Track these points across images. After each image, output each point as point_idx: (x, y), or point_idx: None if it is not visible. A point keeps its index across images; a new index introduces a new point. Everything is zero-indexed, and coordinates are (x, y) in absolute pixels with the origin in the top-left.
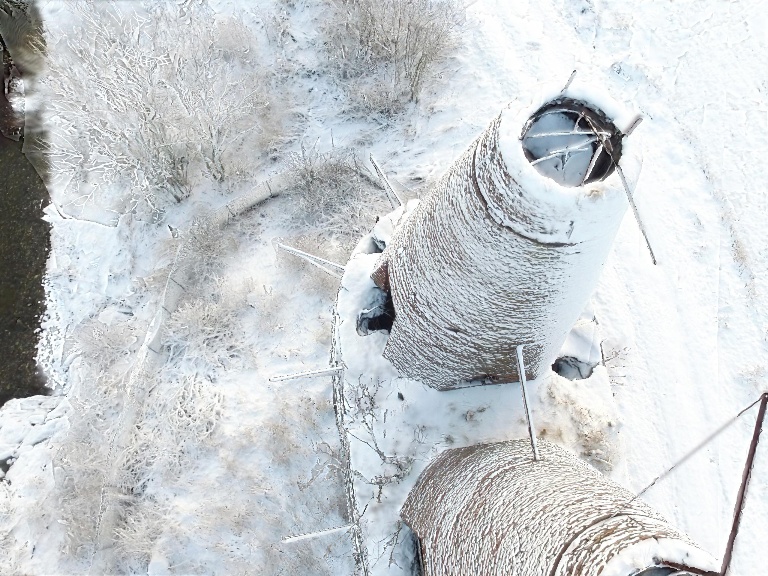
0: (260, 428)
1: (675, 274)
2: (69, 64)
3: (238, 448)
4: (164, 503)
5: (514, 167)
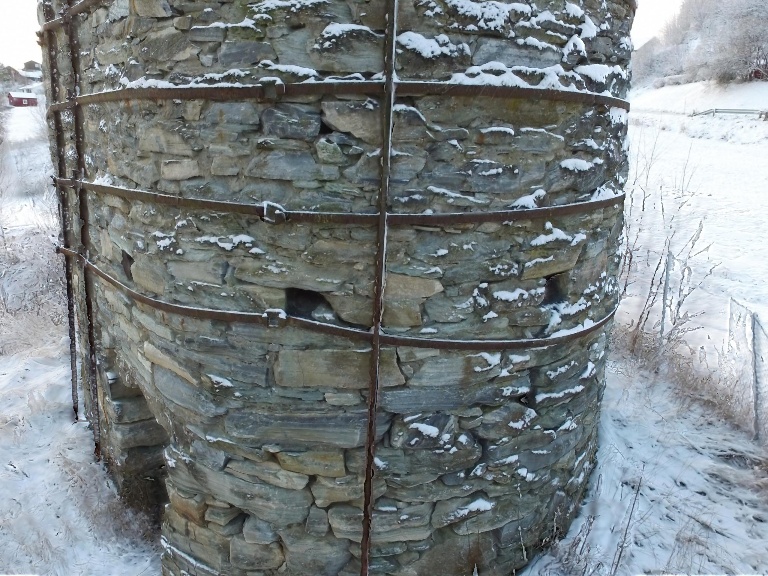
0: None
1: None
2: None
3: None
4: None
5: None
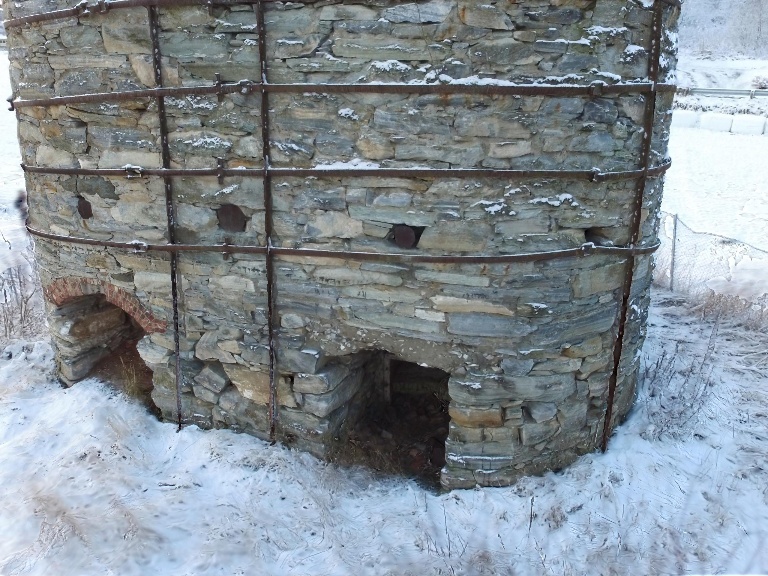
0: (8, 567)
1: None
2: None
3: None
4: None
5: None
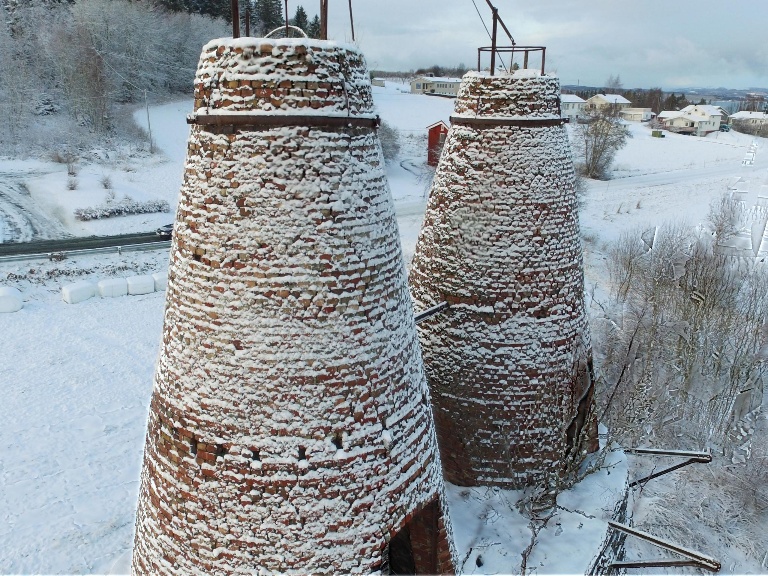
0: None
1: None
2: None
3: None
4: None
5: None
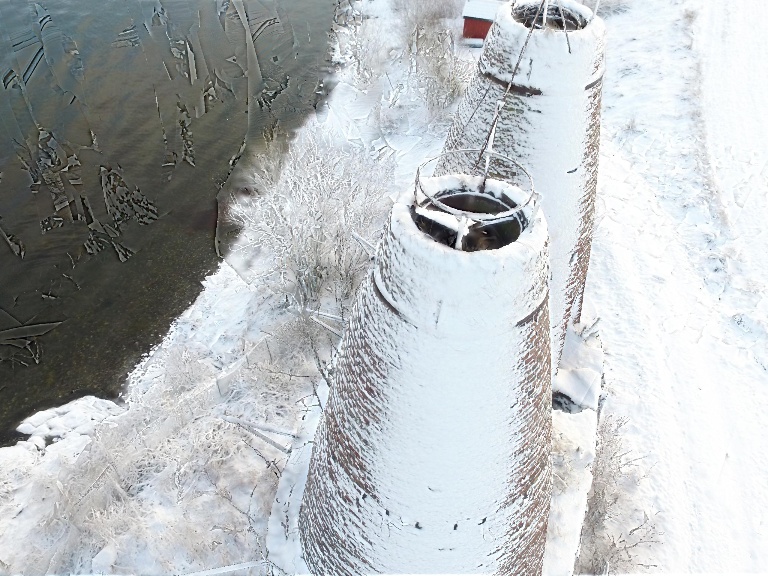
0: (266, 475)
1: (757, 517)
2: (280, 152)
3: (237, 483)
4: (147, 507)
5: (500, 15)
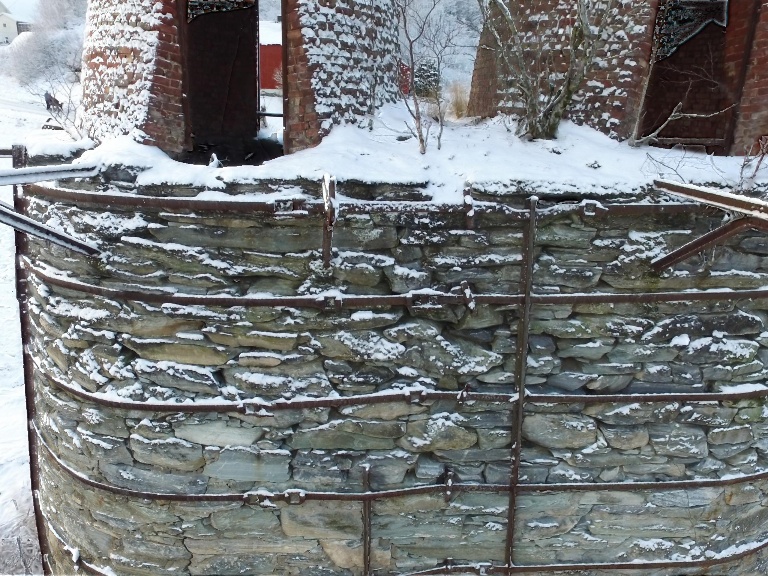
0: None
1: None
2: None
3: None
4: None
5: None
